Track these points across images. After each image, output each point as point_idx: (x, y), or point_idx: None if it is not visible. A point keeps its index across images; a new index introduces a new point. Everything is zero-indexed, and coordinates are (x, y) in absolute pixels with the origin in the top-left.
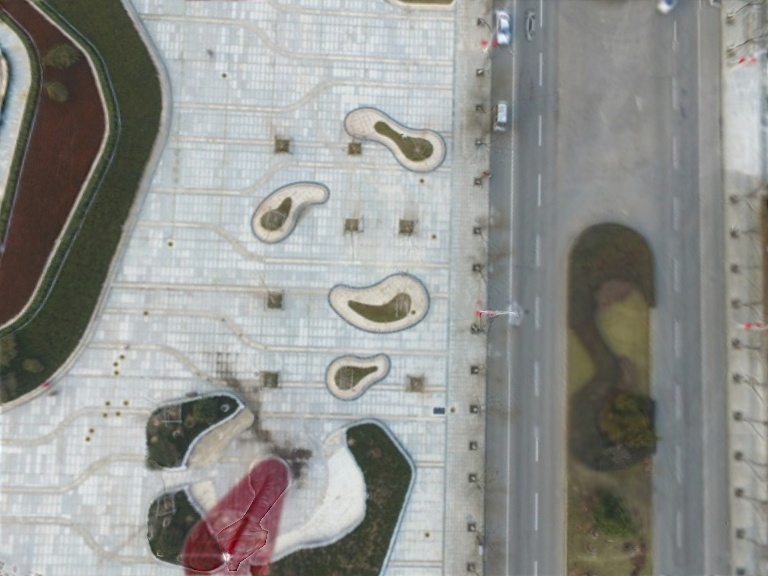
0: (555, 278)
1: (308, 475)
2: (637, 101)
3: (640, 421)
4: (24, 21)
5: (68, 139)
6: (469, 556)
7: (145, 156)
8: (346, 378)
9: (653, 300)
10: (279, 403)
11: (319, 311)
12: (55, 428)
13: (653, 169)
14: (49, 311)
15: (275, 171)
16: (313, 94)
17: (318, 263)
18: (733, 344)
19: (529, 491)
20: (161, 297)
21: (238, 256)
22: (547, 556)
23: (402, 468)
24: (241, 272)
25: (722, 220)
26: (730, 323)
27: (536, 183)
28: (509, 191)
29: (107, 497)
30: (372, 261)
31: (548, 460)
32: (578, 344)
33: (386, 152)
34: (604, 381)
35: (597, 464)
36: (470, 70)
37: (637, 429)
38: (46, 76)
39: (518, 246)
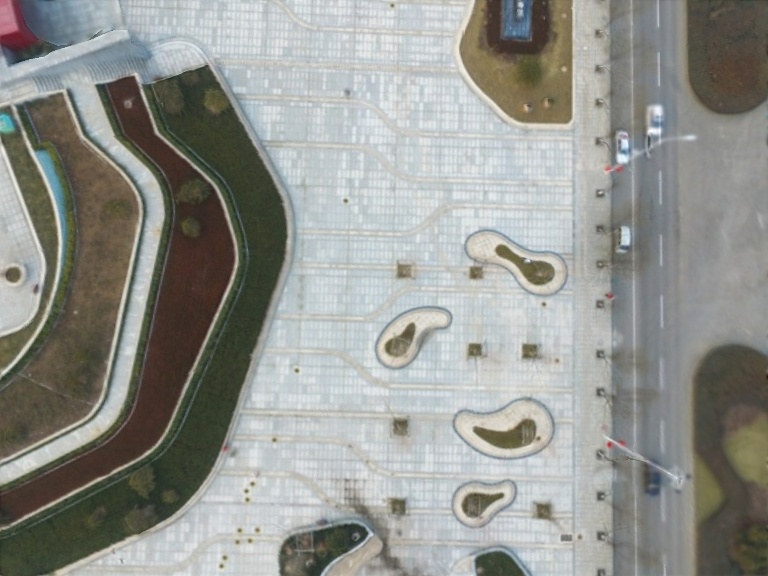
0: (680, 401)
1: None
2: (759, 218)
3: None
4: (156, 156)
5: (200, 272)
6: None
7: (272, 285)
8: (474, 506)
9: None
10: (407, 530)
11: (444, 437)
12: (189, 555)
13: None
14: (183, 441)
15: (398, 296)
16: (433, 217)
17: (442, 388)
18: None
19: None
20: (289, 424)
21: (363, 382)
22: None
23: None
24: (366, 398)
25: None
26: None
27: (658, 304)
28: (631, 313)
29: None
30: (496, 386)
31: None
32: (705, 469)
33: (507, 275)
34: (733, 508)
35: None
36: (590, 190)
37: None
38: (179, 212)
39: (641, 369)
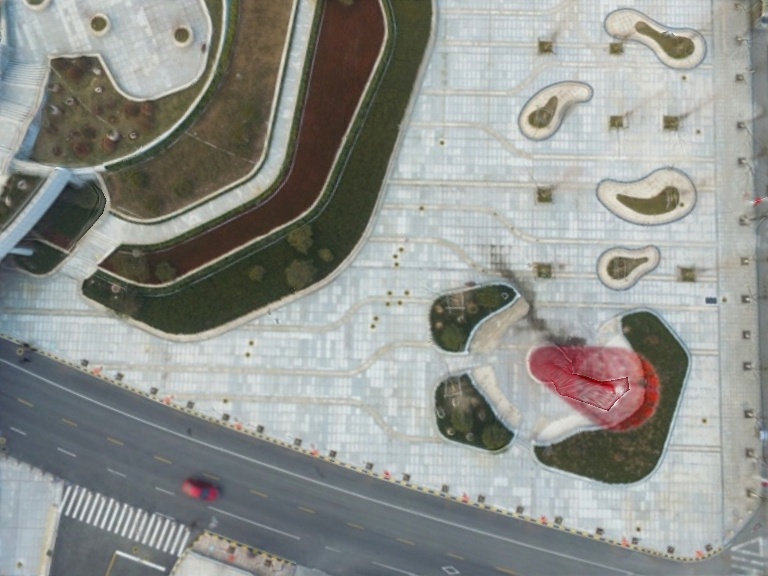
0: None
1: (583, 362)
2: None
3: None
4: None
5: (352, 42)
6: (747, 442)
7: (419, 59)
8: (620, 268)
9: None
10: (553, 292)
11: (588, 205)
12: (342, 316)
13: None
14: (336, 205)
15: (539, 72)
16: None
17: (585, 159)
18: None
19: None
20: (435, 193)
21: (507, 153)
22: None
23: (679, 355)
24: (510, 168)
25: None
26: None
27: None
28: None
29: (393, 380)
30: (638, 156)
31: None
32: None
33: (647, 51)
34: None
35: None
36: None
37: None
38: None
39: None
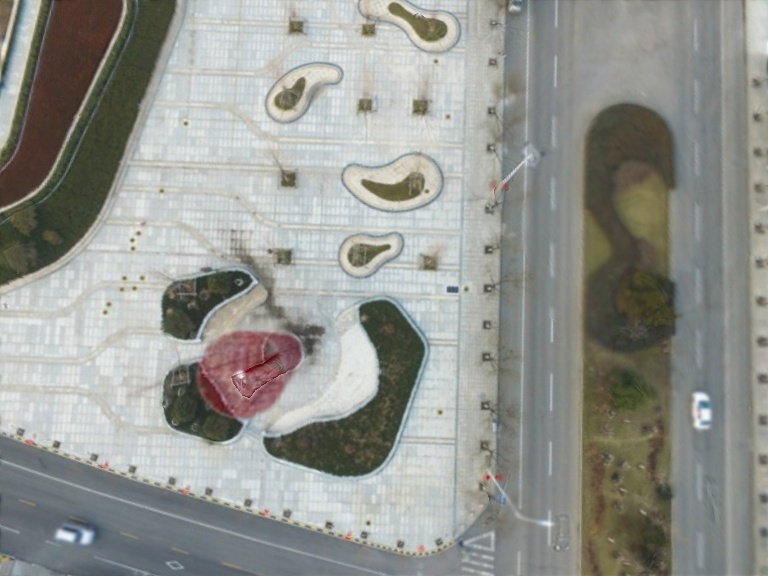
0: (571, 159)
1: (321, 351)
2: None
3: (658, 297)
4: None
5: (87, 16)
6: (482, 434)
7: (161, 36)
8: (359, 255)
9: (672, 181)
10: (292, 279)
11: (332, 190)
12: (74, 301)
13: (673, 51)
14: (68, 186)
15: (289, 52)
16: None
17: (331, 143)
18: (756, 227)
19: (544, 371)
20: (177, 175)
21: (252, 135)
22: (562, 436)
23: (415, 344)
24: (255, 151)
25: (745, 102)
26: (753, 206)
27: (552, 64)
28: (524, 72)
29: (124, 369)
30: (385, 140)
31: (563, 341)
32: (595, 224)
33: (400, 33)
34: (621, 261)
35: (614, 344)
36: None
37: (655, 305)
38: None
39: (533, 127)
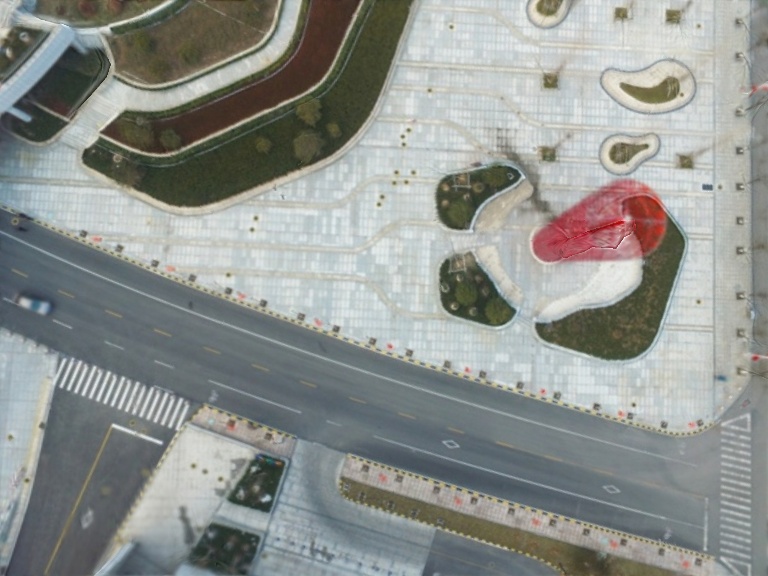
0: None
1: None
2: None
3: None
4: None
5: None
6: (739, 322)
7: None
8: (622, 152)
9: None
10: (557, 176)
11: (592, 92)
12: (348, 193)
13: None
14: (345, 82)
15: None
16: None
17: (590, 48)
18: None
19: None
20: (443, 76)
21: (515, 40)
22: None
23: (676, 237)
24: (518, 55)
25: None
26: None
27: None
28: None
29: (398, 258)
30: (641, 47)
31: None
32: None
33: None
34: None
35: None
36: None
37: None
38: None
39: None
